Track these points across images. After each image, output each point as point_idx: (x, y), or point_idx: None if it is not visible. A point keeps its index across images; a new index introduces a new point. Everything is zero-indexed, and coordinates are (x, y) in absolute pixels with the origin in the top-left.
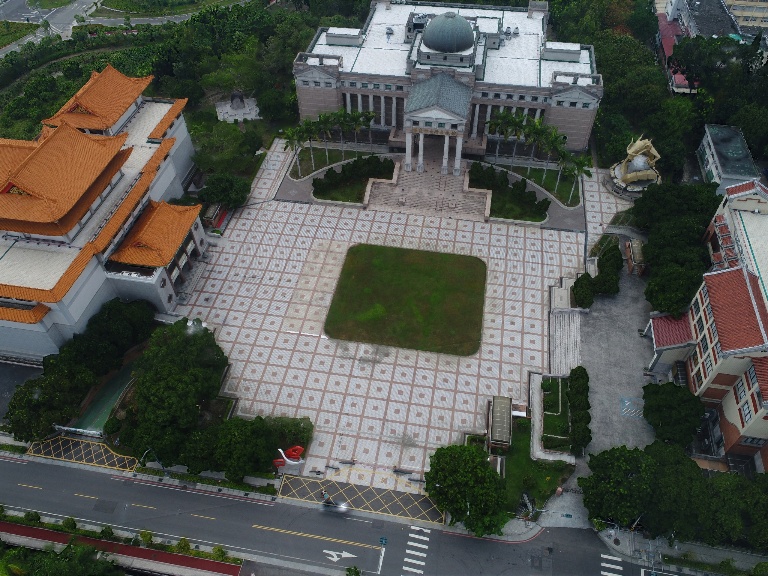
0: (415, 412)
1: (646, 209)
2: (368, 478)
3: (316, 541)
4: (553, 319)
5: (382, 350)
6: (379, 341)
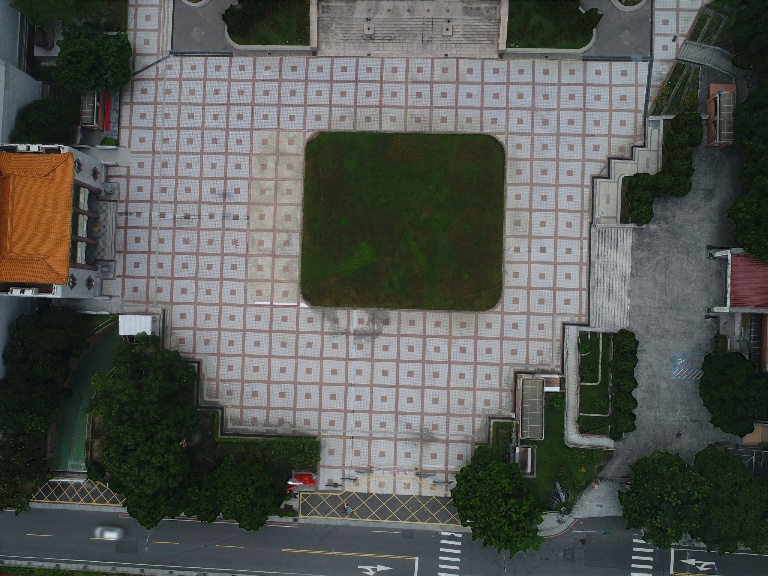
0: (431, 398)
1: (756, 46)
2: (389, 485)
3: (349, 558)
4: (595, 235)
5: (380, 316)
6: (374, 303)
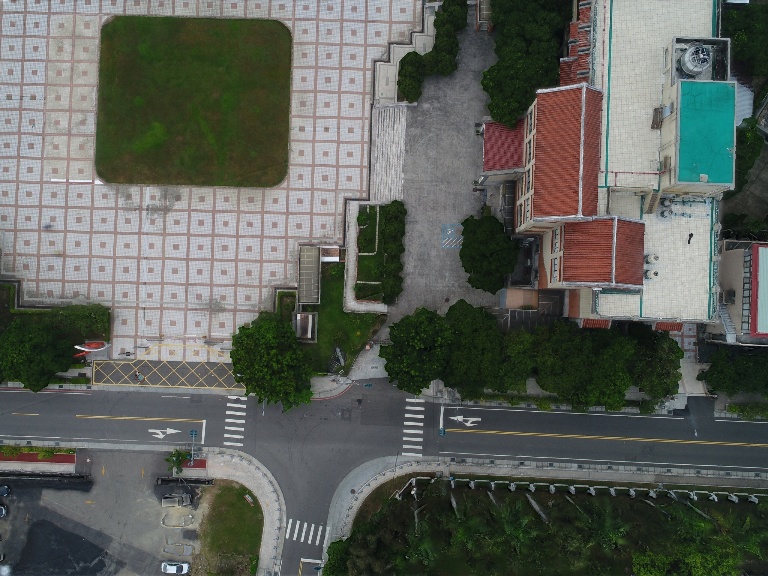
0: (219, 270)
1: None
2: (179, 353)
3: (140, 423)
4: (376, 116)
5: (171, 192)
6: (166, 180)
